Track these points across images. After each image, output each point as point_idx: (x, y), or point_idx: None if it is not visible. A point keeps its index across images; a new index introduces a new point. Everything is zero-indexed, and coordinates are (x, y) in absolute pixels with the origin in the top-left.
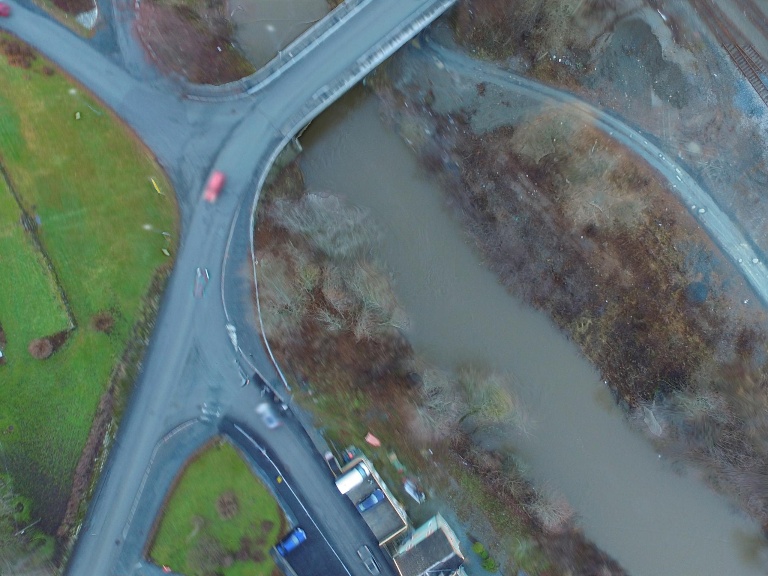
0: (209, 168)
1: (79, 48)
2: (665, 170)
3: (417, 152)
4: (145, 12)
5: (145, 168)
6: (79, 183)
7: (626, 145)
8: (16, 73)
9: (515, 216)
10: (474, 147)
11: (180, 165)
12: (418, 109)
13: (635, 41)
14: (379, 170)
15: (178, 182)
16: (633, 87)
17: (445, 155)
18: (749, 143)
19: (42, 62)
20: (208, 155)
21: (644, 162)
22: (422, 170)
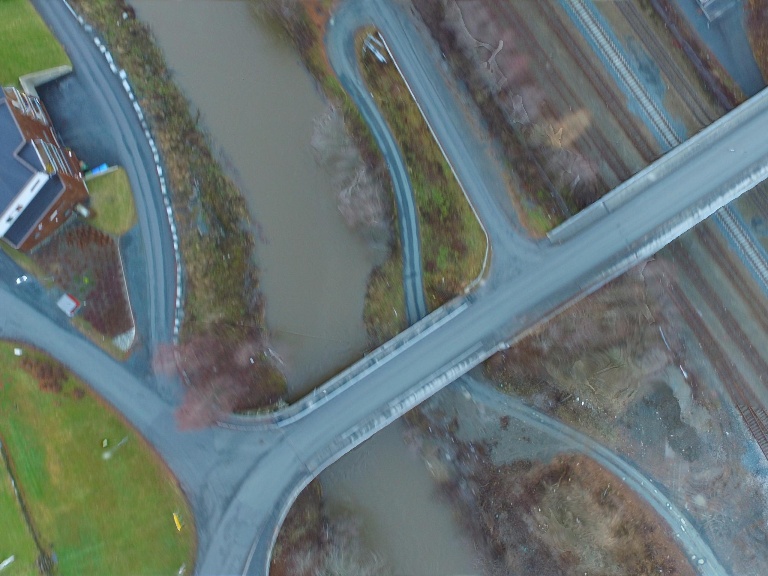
0: (231, 497)
1: (113, 370)
2: (671, 519)
3: (436, 475)
4: (183, 336)
5: (167, 494)
6: (100, 516)
7: (637, 492)
8: (46, 399)
9: (524, 546)
10: (492, 477)
11: (202, 492)
12: (441, 434)
13: (656, 395)
14: (397, 489)
15: (199, 509)
16: (649, 437)
17: (463, 481)
18: (752, 501)
19: (73, 383)
20: (232, 484)
21: (652, 510)
22: (439, 496)
